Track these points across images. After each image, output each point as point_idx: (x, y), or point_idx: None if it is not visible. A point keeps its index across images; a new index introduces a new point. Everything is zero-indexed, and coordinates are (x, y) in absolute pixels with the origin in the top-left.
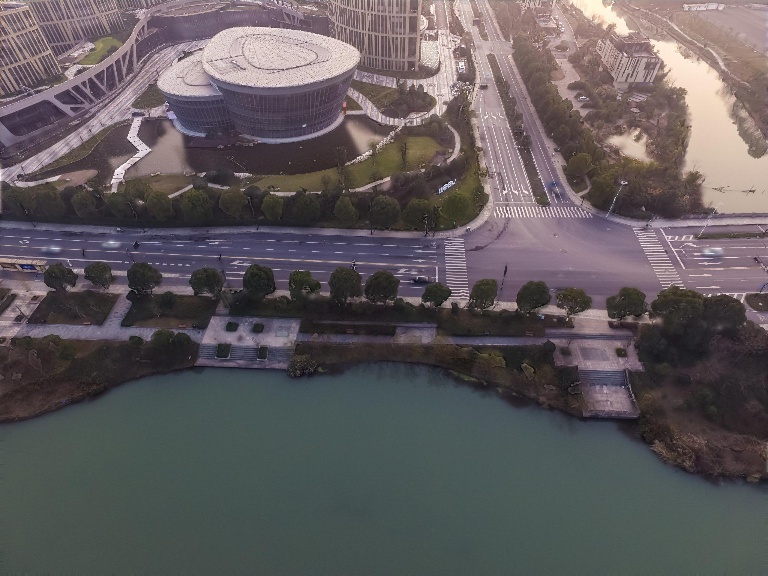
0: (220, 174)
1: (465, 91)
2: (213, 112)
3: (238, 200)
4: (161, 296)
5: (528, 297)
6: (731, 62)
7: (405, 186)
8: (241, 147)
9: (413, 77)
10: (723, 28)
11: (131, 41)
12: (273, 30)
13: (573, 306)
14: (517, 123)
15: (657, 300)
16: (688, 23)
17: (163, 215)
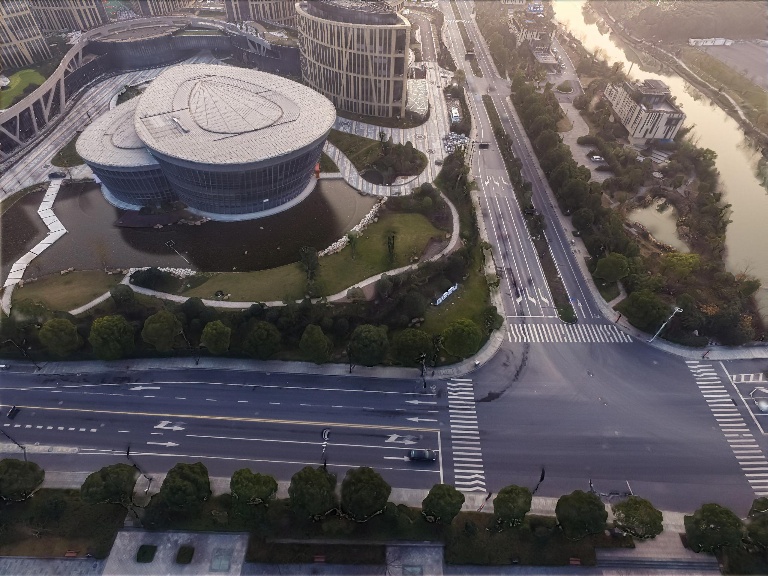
0: (151, 277)
1: (462, 151)
2: (148, 183)
3: (168, 330)
4: None
5: (577, 523)
6: (751, 111)
7: (393, 294)
8: (185, 227)
9: (399, 126)
10: (736, 69)
11: (57, 75)
12: (230, 70)
13: (640, 533)
14: (525, 195)
15: (759, 529)
16: (697, 61)
17: (63, 350)
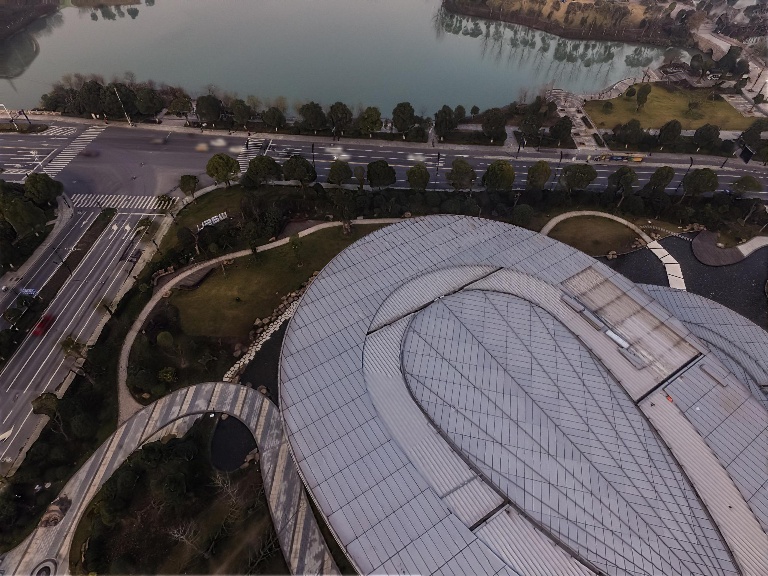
0: None
1: None
2: None
3: None
4: (480, 133)
5: None
6: None
7: None
8: None
9: None
10: None
11: None
12: None
13: None
14: None
15: (131, 93)
16: None
17: None
